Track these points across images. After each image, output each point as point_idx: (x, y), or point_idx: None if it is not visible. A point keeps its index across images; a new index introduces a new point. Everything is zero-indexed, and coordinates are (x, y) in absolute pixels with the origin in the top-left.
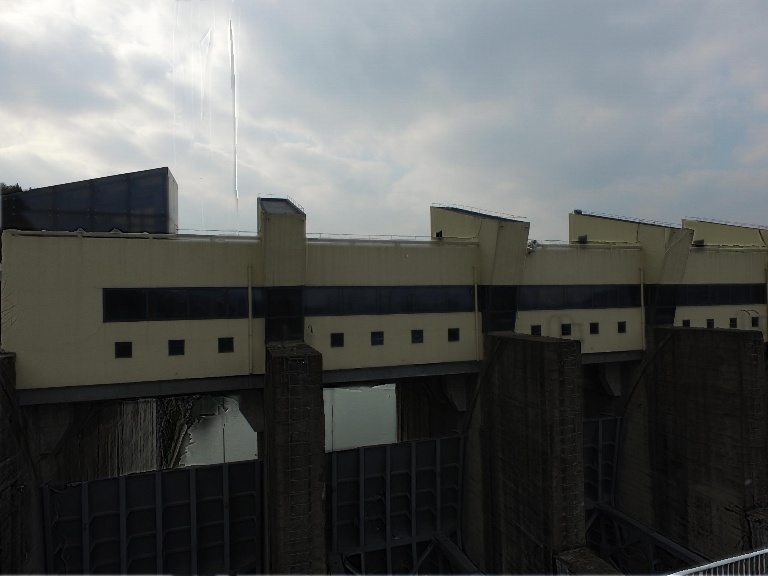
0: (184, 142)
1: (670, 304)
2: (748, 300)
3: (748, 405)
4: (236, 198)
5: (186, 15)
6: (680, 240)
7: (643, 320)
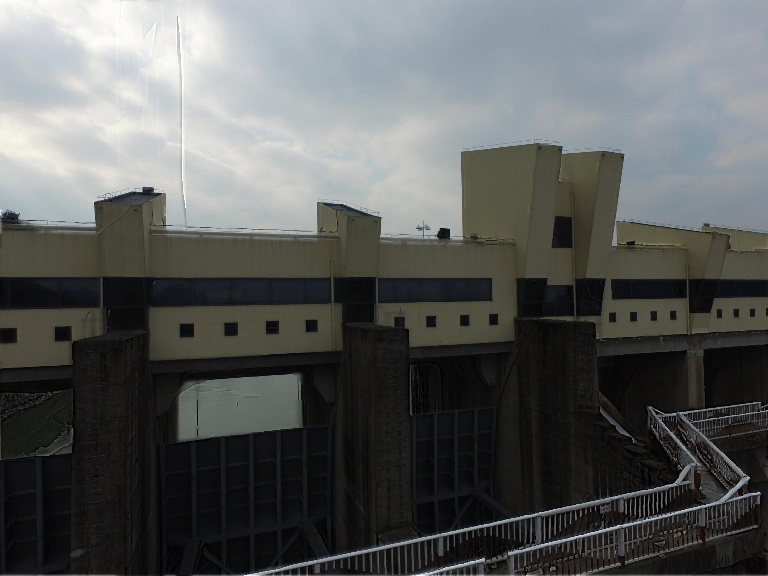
0: (130, 138)
1: (135, 303)
2: (303, 299)
3: (85, 444)
4: (182, 197)
5: (132, 8)
6: (119, 218)
7: (101, 324)
